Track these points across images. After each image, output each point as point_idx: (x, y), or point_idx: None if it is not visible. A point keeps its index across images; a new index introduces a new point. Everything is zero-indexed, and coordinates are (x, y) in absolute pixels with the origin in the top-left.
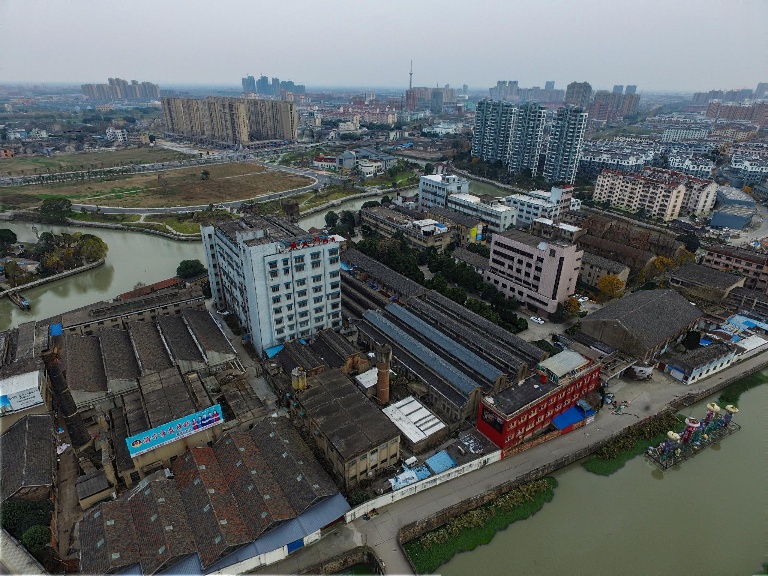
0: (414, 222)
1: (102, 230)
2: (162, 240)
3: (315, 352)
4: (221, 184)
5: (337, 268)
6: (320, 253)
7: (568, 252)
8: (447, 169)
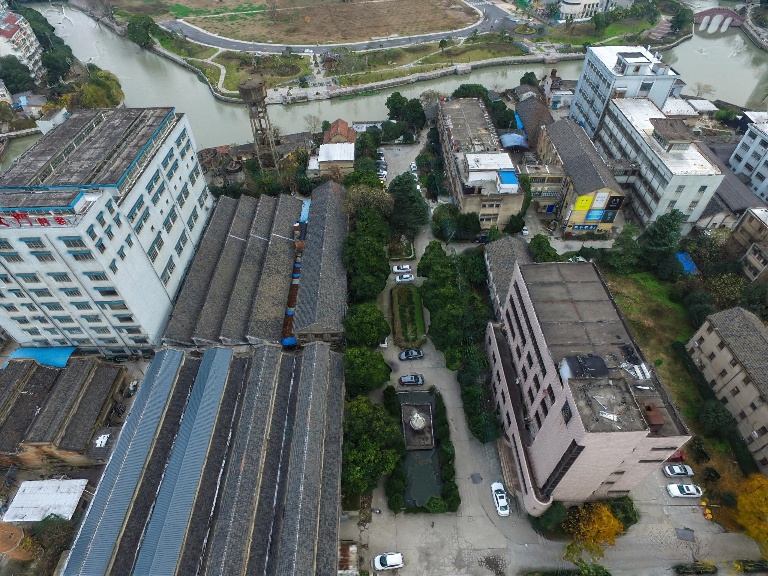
0: (468, 156)
1: (175, 64)
2: (211, 91)
3: (48, 391)
4: (353, 12)
5: (98, 268)
6: (43, 240)
7: (605, 439)
8: (732, 22)
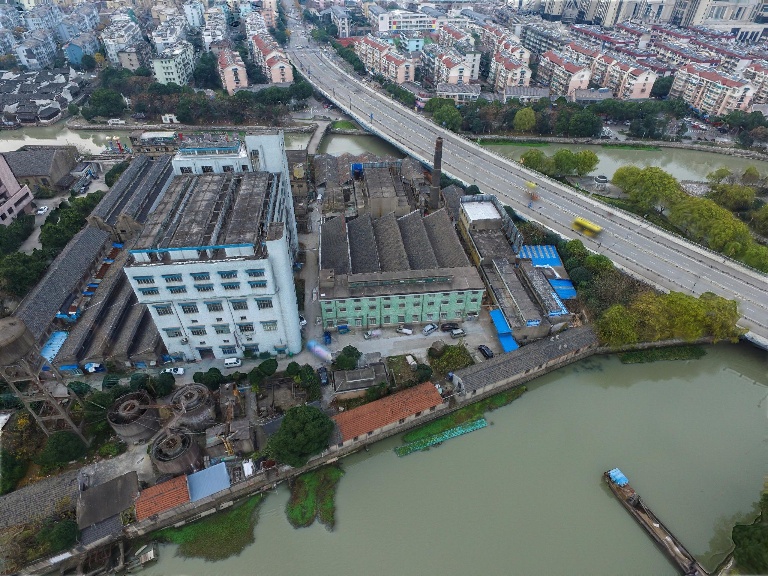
0: None
1: None
2: None
3: None
4: None
5: None
6: None
7: None
8: None
